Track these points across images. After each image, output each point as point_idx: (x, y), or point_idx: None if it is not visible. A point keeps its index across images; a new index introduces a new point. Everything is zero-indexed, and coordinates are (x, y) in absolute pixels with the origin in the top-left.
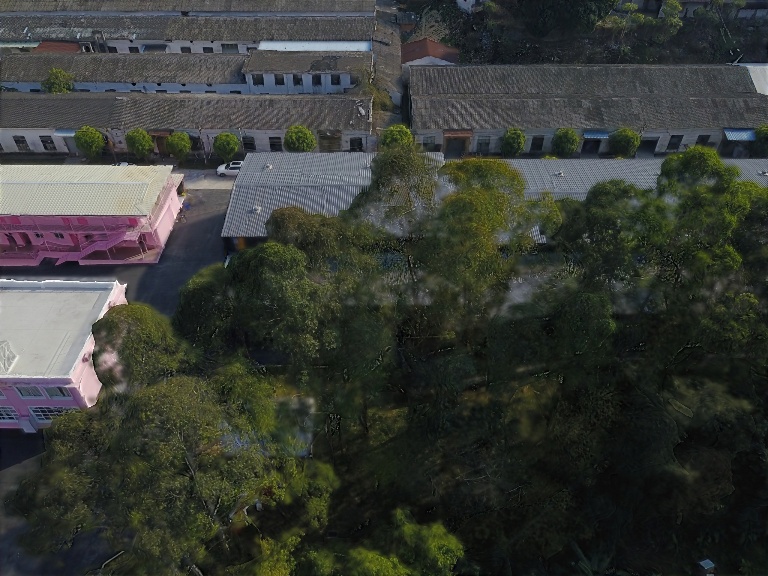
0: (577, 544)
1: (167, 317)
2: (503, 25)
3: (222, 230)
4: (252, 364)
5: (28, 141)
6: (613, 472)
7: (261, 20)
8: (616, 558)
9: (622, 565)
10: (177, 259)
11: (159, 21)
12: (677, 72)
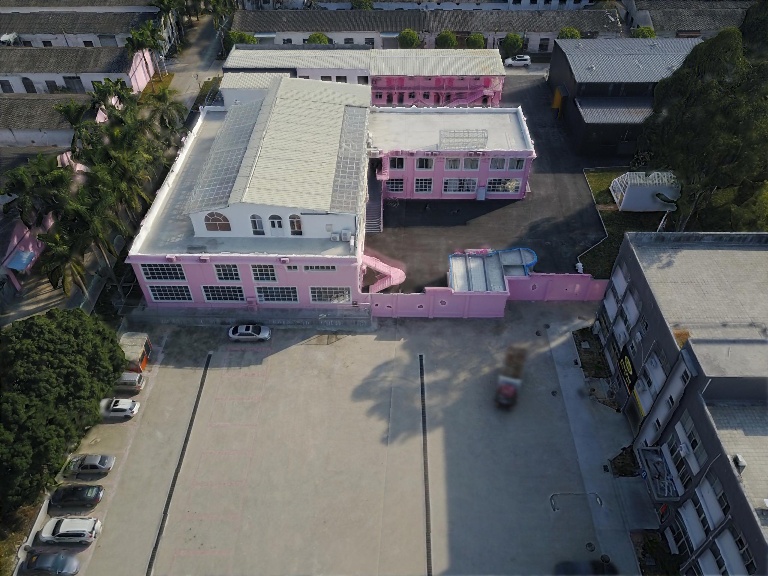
0: None
1: None
2: None
3: (576, 79)
4: None
5: (355, 43)
6: None
7: None
8: None
9: None
10: None
11: None
12: None
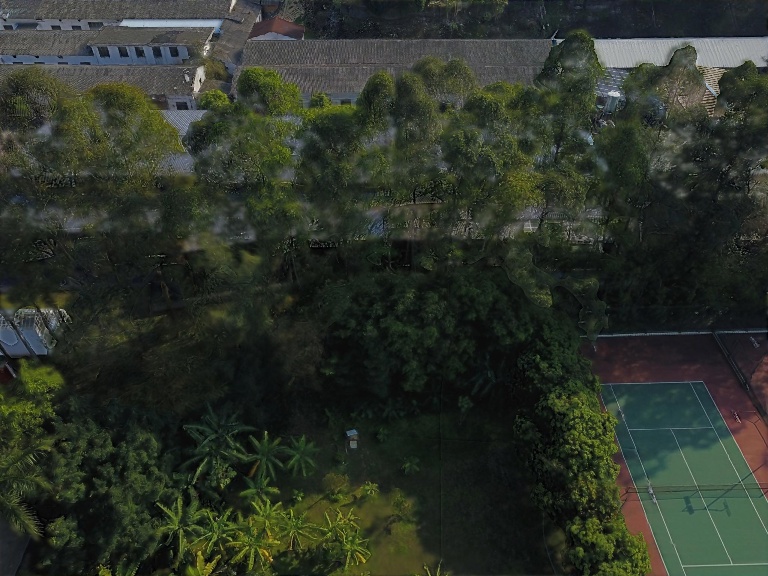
0: (209, 403)
1: None
2: (348, 5)
3: None
4: None
5: None
6: (235, 342)
7: (126, 1)
8: (246, 416)
9: (278, 432)
10: None
11: (32, 2)
12: (488, 44)
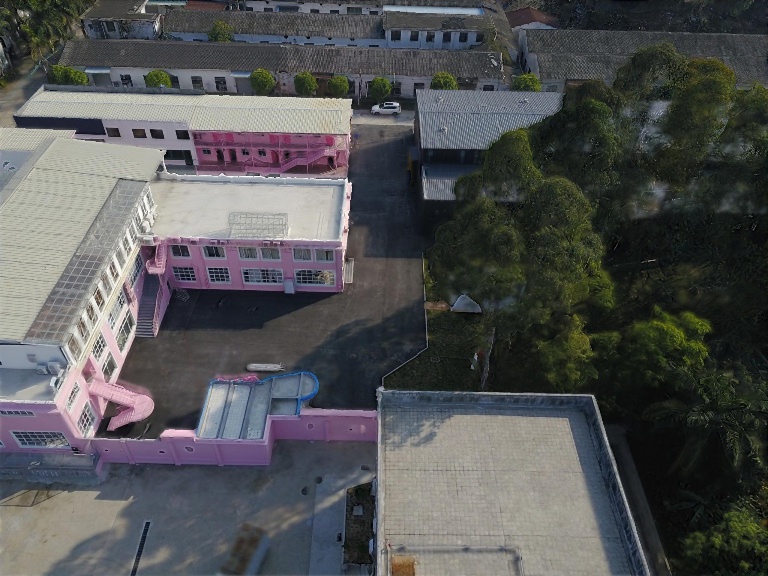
0: (760, 352)
1: (370, 216)
2: None
3: (421, 143)
4: (576, 186)
5: (204, 81)
6: None
7: None
8: None
9: None
10: (362, 175)
11: None
12: (755, 39)
